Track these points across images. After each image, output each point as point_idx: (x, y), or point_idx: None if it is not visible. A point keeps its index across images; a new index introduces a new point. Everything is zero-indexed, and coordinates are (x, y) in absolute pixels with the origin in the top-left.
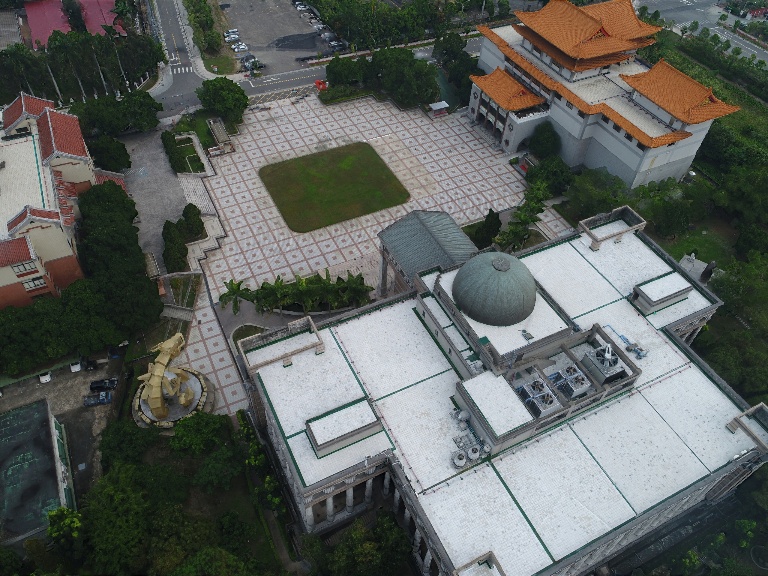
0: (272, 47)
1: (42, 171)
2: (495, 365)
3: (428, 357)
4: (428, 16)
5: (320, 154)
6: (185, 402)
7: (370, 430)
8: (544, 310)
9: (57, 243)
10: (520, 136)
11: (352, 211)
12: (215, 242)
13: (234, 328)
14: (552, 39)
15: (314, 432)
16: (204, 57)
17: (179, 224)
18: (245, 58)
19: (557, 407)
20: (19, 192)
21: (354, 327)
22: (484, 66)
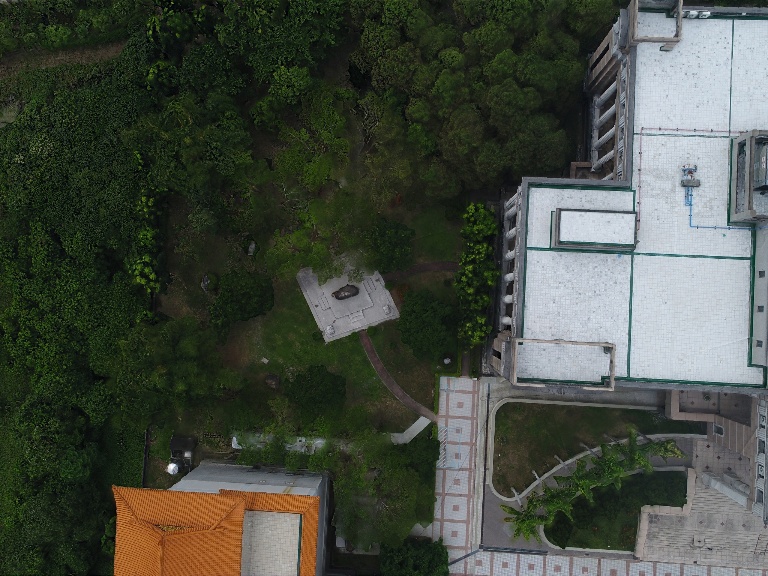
0: None
1: None
2: None
3: None
4: None
5: None
6: None
7: None
8: None
9: None
10: None
11: None
12: None
13: None
14: None
15: None
16: None
17: None
18: None
19: None
20: None
21: None
22: None
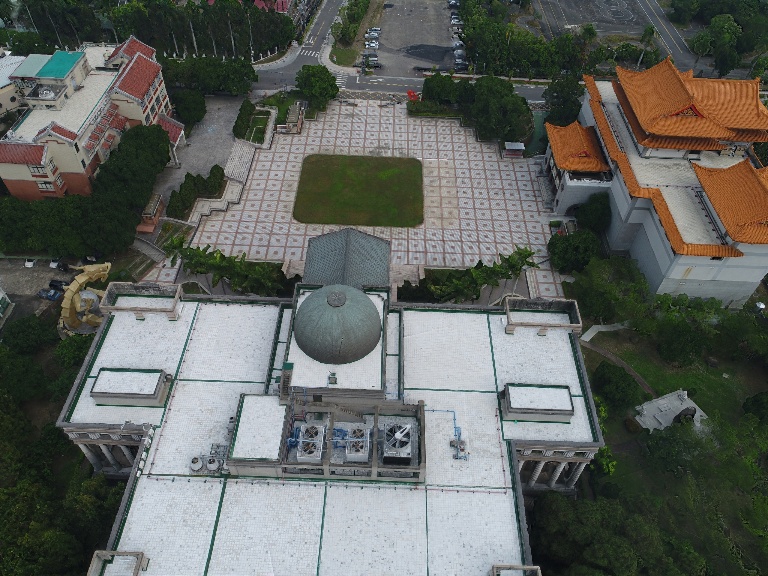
0: (402, 51)
1: (102, 101)
2: (287, 394)
3: (256, 363)
4: (567, 56)
5: (369, 158)
6: (89, 322)
7: (148, 401)
8: (372, 363)
9: (70, 159)
10: (570, 199)
11: (358, 218)
12: (224, 205)
13: (185, 281)
14: (636, 105)
15: (99, 380)
16: (334, 46)
17: (197, 179)
18: (368, 55)
19: (318, 461)
20: (74, 112)
21: (219, 311)
22: (582, 118)
